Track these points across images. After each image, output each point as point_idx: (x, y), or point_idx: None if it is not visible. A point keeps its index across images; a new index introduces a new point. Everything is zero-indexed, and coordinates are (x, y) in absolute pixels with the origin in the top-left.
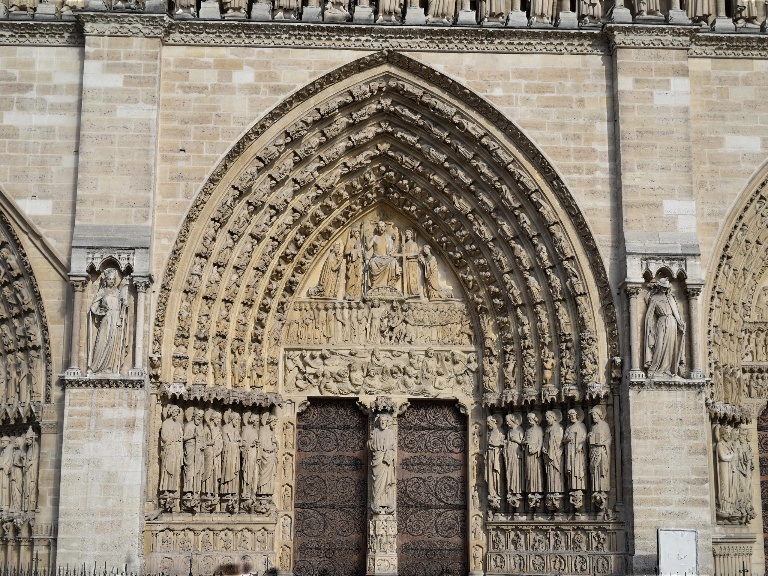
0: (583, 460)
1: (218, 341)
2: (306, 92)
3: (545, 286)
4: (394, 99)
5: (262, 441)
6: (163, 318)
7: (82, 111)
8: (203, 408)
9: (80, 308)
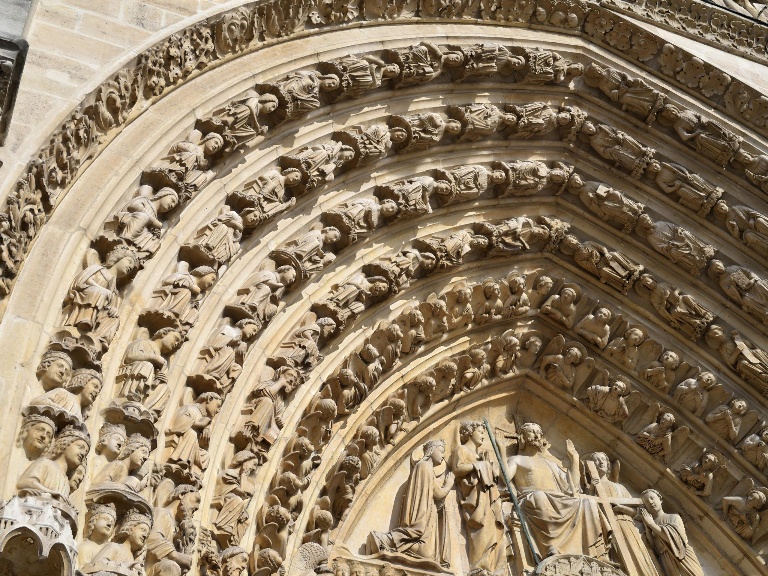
0: None
1: None
2: None
3: None
4: (590, 114)
5: None
6: (11, 265)
7: None
8: None
9: None
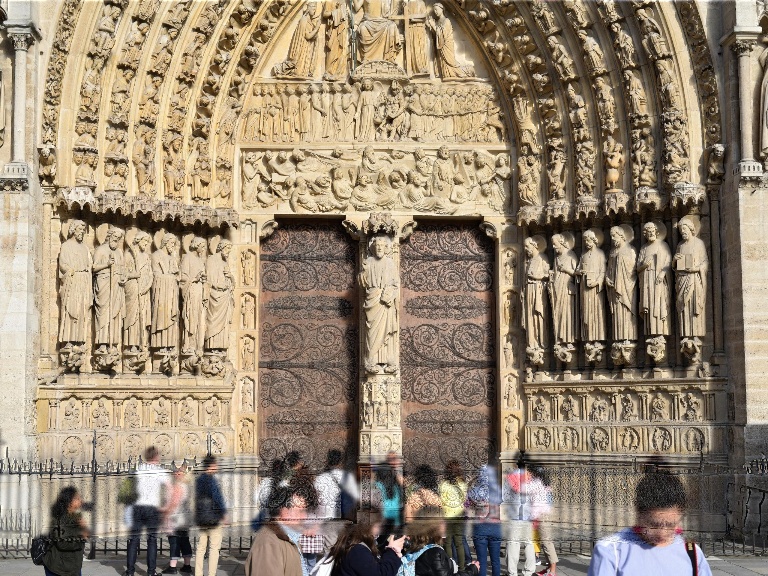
0: (666, 293)
1: (142, 131)
2: None
3: (609, 50)
4: None
5: (210, 275)
6: (57, 93)
7: None
8: (123, 227)
9: None
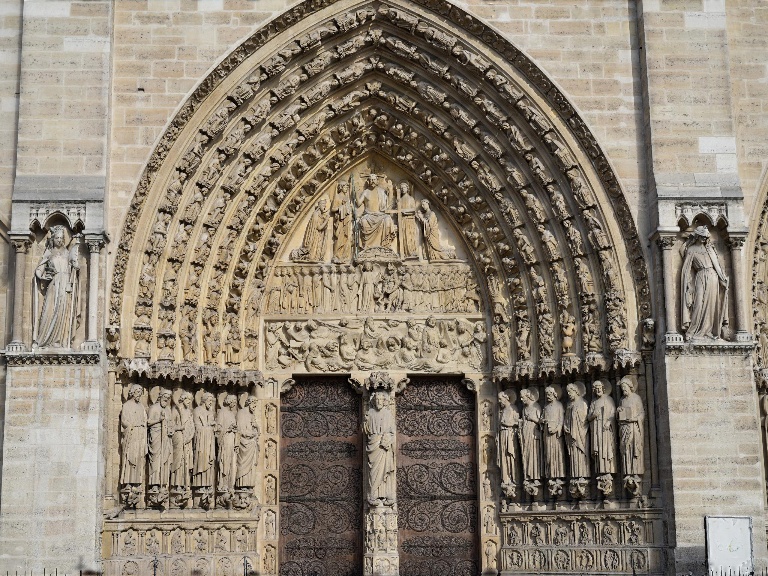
0: (612, 439)
1: (187, 310)
2: (283, 21)
3: (563, 241)
4: (385, 30)
5: (240, 425)
6: (121, 283)
7: (23, 45)
8: (171, 388)
9: (23, 272)
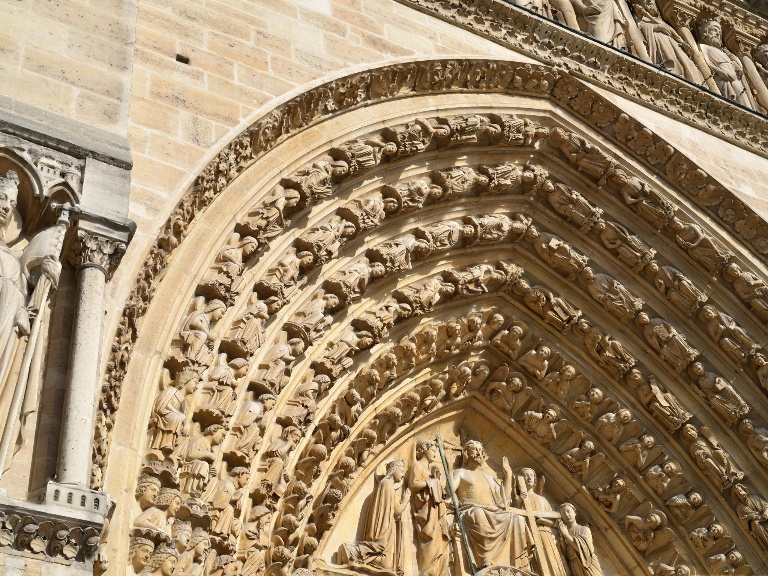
0: None
1: (216, 560)
2: None
3: None
4: (551, 172)
5: None
6: (115, 403)
7: None
8: None
9: None
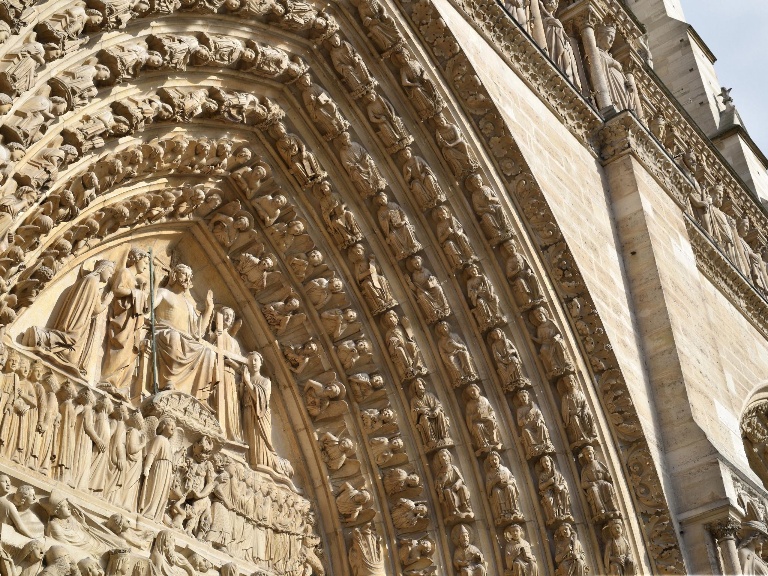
0: None
1: None
2: None
3: (526, 491)
4: (341, 27)
5: None
6: None
7: None
8: None
9: None
